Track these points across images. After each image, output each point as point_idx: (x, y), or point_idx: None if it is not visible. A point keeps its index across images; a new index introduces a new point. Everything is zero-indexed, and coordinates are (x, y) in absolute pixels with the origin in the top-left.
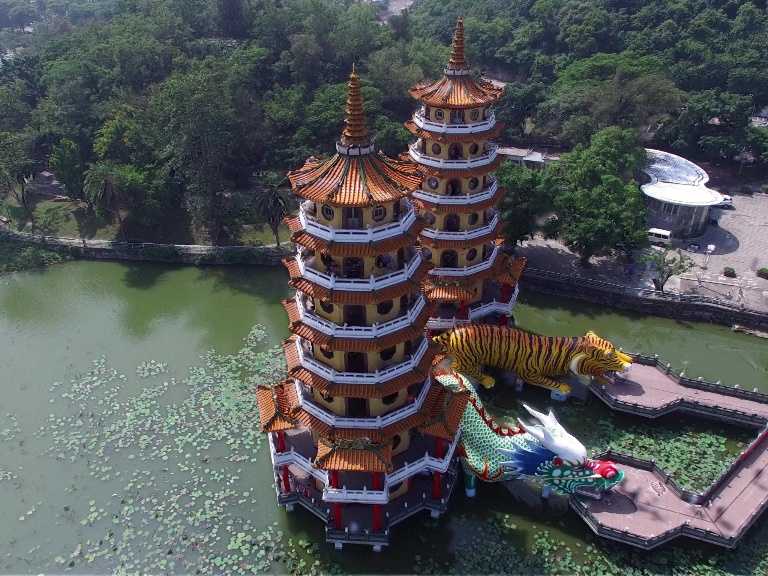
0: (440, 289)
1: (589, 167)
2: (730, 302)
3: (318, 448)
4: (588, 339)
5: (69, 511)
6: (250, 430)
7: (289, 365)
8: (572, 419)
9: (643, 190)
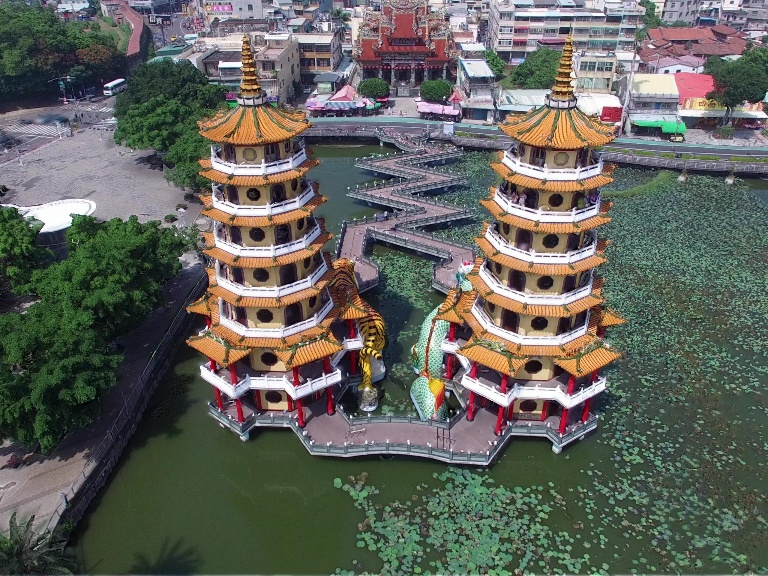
0: (354, 302)
1: (26, 234)
2: None
3: (607, 324)
4: (343, 265)
5: None
6: (518, 505)
7: (592, 304)
8: (385, 310)
9: (43, 232)
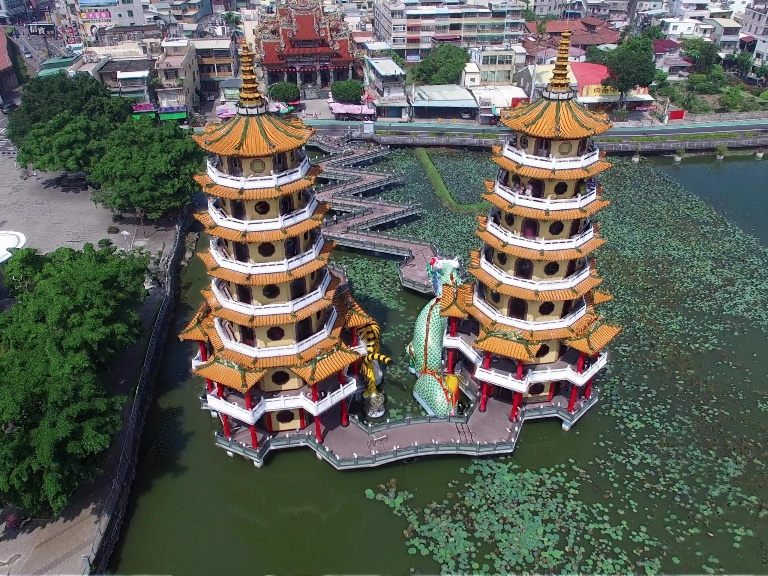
0: (355, 309)
1: None
2: (163, 256)
3: None
4: None
5: (763, 555)
6: (548, 485)
7: (594, 284)
8: None
9: None
